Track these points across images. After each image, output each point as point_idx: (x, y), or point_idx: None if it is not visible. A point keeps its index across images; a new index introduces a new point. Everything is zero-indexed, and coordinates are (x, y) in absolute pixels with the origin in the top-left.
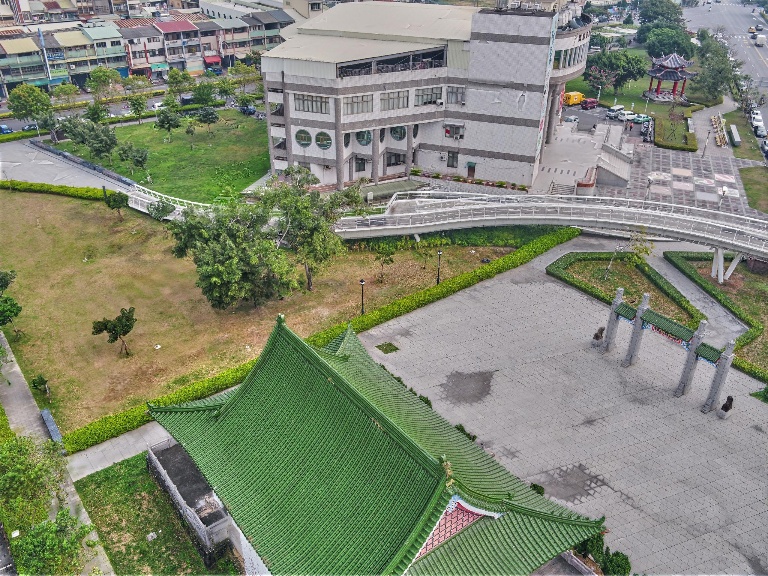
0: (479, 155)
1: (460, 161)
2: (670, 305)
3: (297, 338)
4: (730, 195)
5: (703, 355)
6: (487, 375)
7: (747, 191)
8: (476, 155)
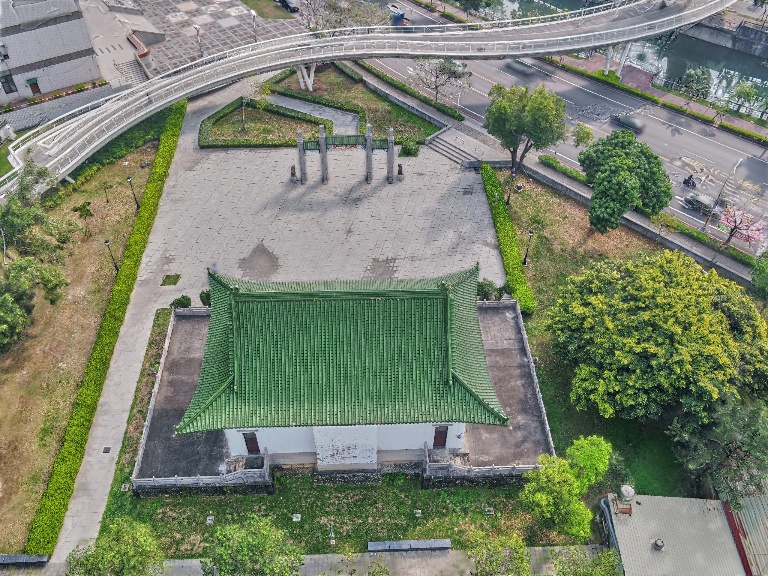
0: (35, 68)
1: (17, 83)
2: (302, 124)
3: (263, 293)
4: (241, 13)
5: (378, 147)
6: (261, 248)
7: (247, 4)
8: (32, 69)
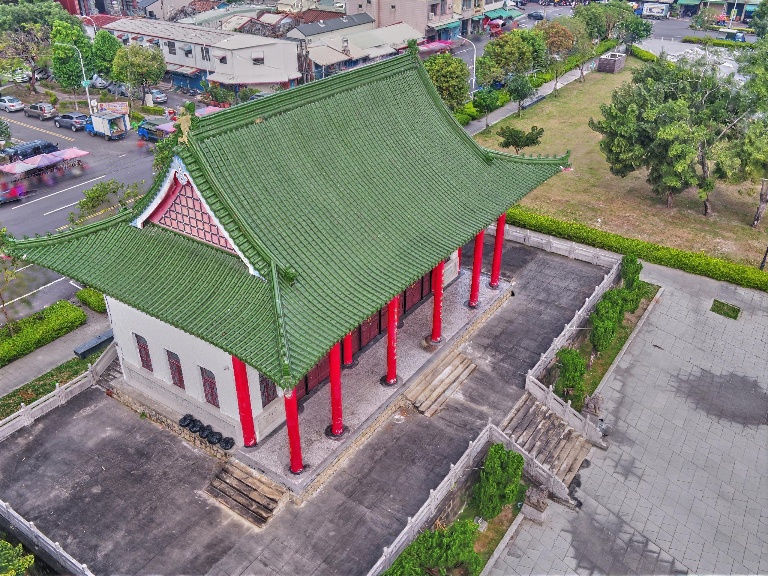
0: None
1: None
2: None
3: None
4: None
5: None
6: None
7: None
8: None
